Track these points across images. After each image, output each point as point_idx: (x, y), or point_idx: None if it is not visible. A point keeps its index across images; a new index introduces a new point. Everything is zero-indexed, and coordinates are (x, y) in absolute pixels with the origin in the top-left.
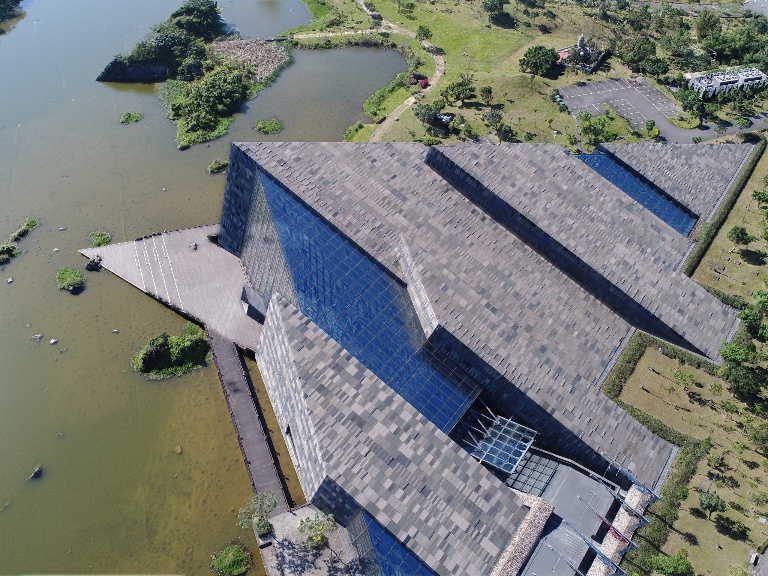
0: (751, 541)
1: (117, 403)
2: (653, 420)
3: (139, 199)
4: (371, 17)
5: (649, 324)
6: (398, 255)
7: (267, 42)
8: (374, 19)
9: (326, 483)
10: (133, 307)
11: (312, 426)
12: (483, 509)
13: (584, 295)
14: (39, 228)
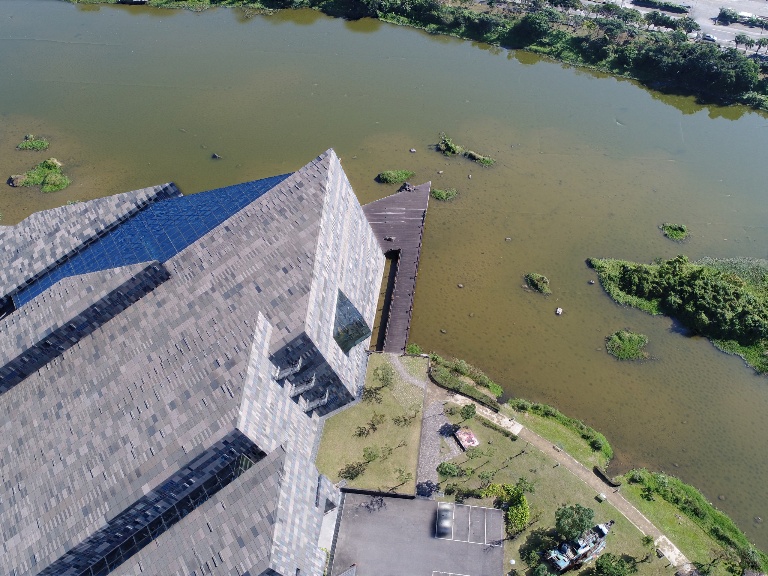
0: None
1: None
2: None
3: (499, 221)
4: None
5: None
6: None
7: None
8: None
9: None
10: None
11: None
12: None
13: None
14: (479, 165)
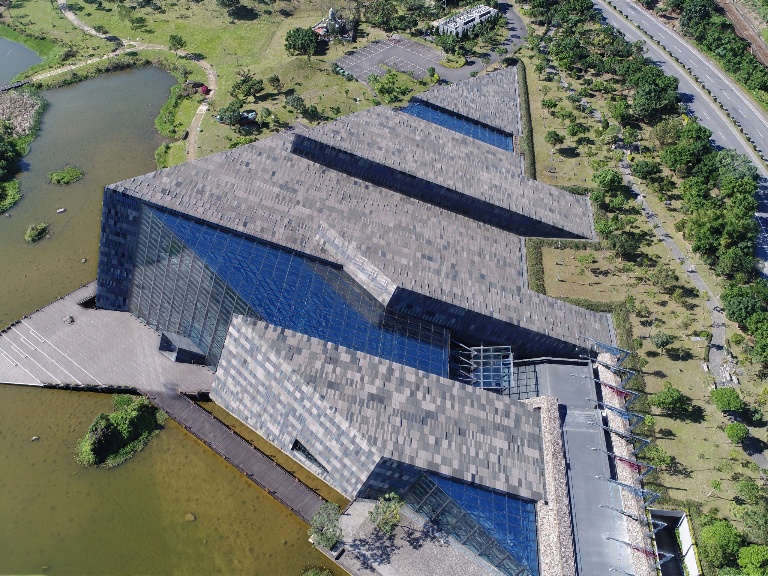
0: (696, 357)
1: (89, 507)
2: (582, 301)
3: None
4: (106, 40)
5: (534, 229)
6: (322, 242)
7: (4, 92)
8: (110, 41)
9: (380, 466)
10: (38, 407)
11: (343, 421)
12: (510, 426)
13: (475, 224)
14: None
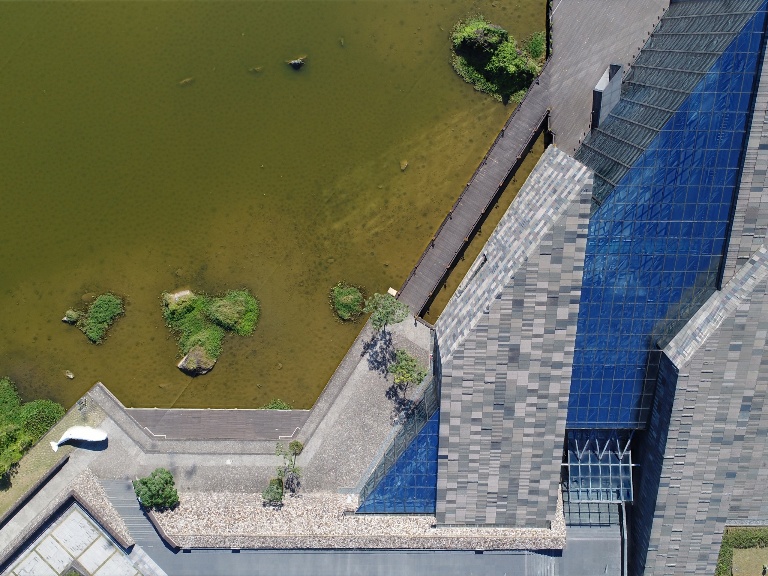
0: None
1: (407, 59)
2: None
3: None
4: None
5: None
6: (755, 257)
7: None
8: None
9: None
10: None
11: (475, 322)
12: (519, 494)
13: None
14: None
